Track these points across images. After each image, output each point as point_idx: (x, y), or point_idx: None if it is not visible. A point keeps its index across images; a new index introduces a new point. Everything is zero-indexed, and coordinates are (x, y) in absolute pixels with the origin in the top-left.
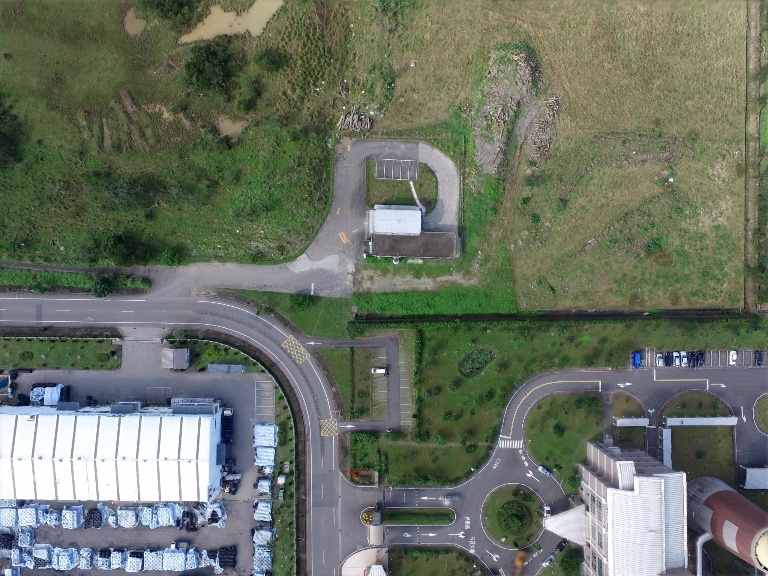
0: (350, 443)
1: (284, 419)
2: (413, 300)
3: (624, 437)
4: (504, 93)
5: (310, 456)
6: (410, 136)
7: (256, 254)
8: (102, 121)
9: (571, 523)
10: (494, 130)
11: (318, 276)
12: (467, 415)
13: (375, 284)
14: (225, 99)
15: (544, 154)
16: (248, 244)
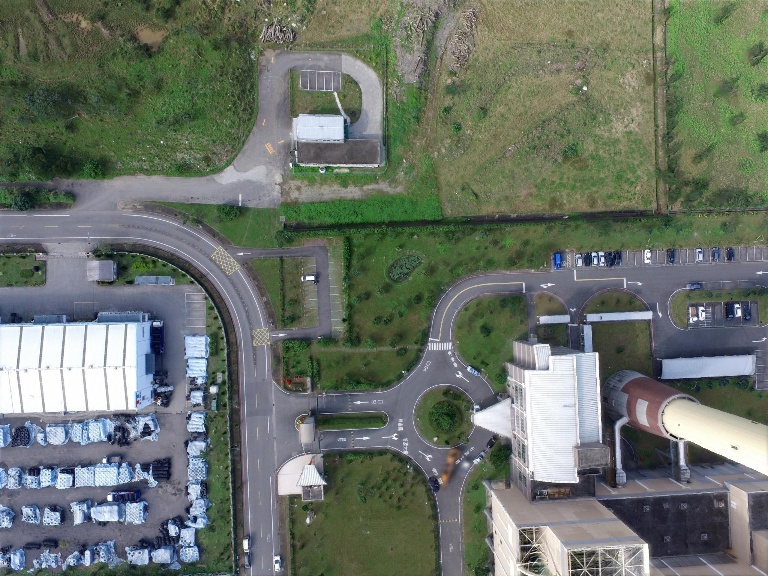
0: (282, 351)
1: (215, 330)
2: (340, 208)
3: (548, 335)
4: (422, 4)
5: (243, 366)
6: (333, 48)
7: (182, 166)
8: (17, 31)
9: (498, 416)
10: (414, 40)
11: (246, 187)
12: (397, 319)
13: (303, 194)
14: (143, 7)
15: (464, 64)
16: (173, 156)
